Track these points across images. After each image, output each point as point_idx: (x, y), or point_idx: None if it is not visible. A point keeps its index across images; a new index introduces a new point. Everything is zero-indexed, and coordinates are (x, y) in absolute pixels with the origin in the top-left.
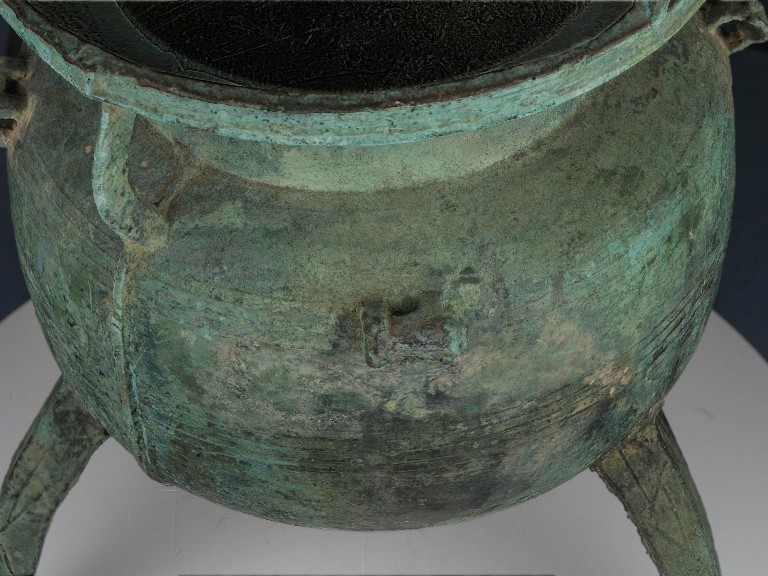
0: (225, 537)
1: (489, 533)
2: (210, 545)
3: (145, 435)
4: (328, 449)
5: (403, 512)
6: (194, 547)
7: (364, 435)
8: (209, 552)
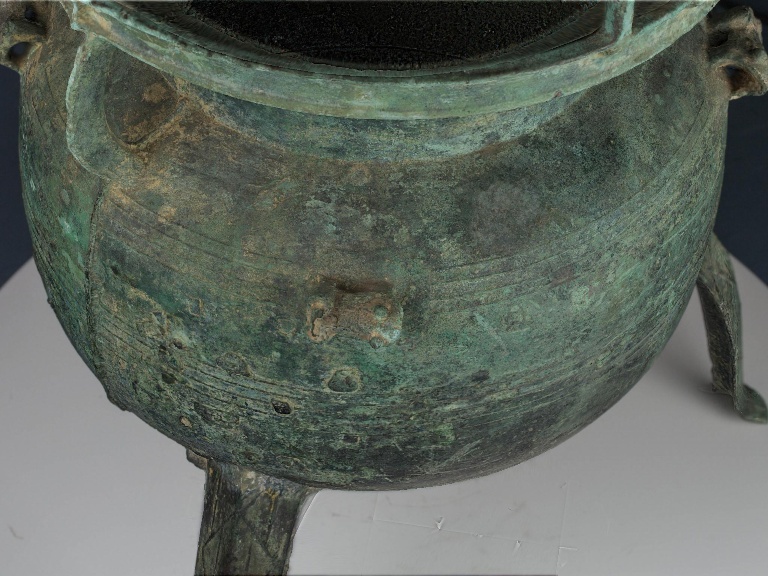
0: (516, 492)
1: None
2: (531, 487)
3: None
4: None
5: (397, 0)
6: (547, 488)
7: None
8: (533, 481)
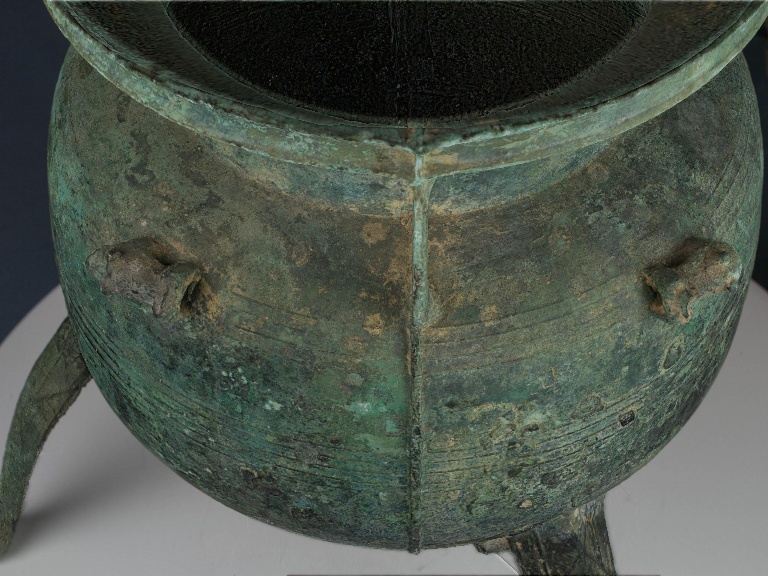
0: None
1: (313, 572)
2: None
3: (390, 10)
4: (225, 3)
5: None
6: None
7: (199, 0)
8: None
